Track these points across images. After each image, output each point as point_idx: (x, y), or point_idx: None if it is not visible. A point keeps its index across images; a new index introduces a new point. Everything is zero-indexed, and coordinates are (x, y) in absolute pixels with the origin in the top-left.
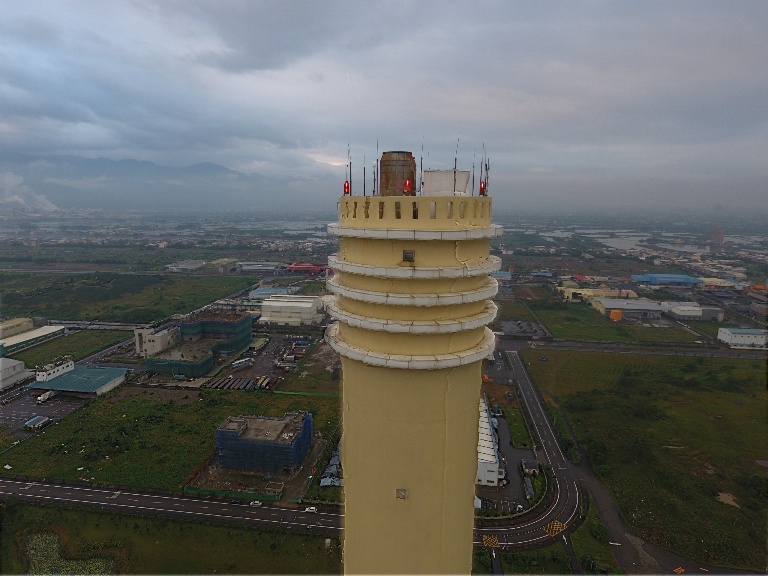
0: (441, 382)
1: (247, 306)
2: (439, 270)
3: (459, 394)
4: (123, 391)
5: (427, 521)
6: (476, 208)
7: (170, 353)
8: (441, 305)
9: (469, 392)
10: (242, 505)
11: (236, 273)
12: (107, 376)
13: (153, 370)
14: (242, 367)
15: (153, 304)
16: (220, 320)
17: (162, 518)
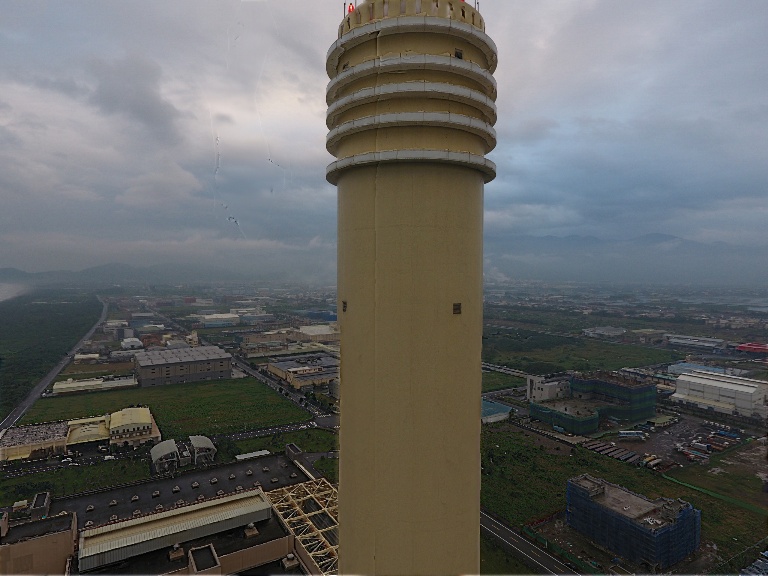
0: (369, 186)
1: (660, 379)
2: (352, 67)
3: (392, 203)
4: (504, 426)
5: (361, 340)
6: (406, 3)
7: (554, 404)
8: (356, 101)
9: (407, 203)
10: (577, 573)
11: (661, 345)
12: (494, 409)
13: (536, 416)
14: (631, 438)
15: (558, 361)
16: (615, 383)
17: (494, 542)
